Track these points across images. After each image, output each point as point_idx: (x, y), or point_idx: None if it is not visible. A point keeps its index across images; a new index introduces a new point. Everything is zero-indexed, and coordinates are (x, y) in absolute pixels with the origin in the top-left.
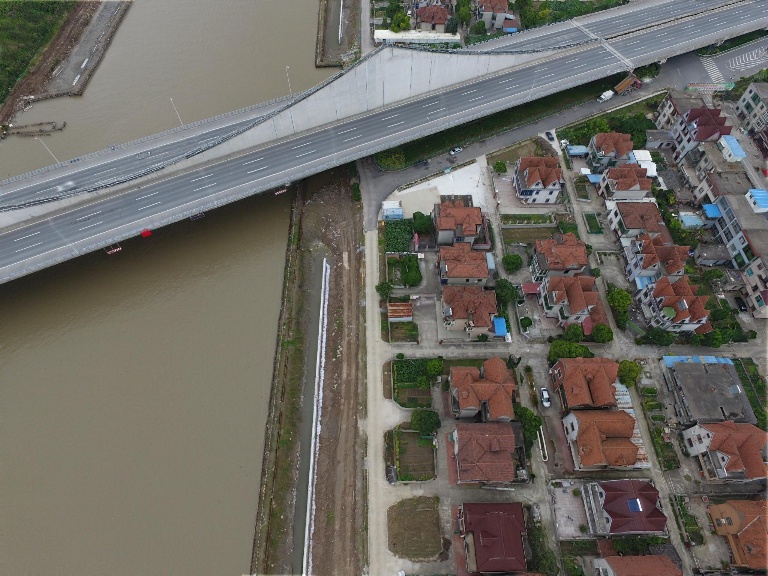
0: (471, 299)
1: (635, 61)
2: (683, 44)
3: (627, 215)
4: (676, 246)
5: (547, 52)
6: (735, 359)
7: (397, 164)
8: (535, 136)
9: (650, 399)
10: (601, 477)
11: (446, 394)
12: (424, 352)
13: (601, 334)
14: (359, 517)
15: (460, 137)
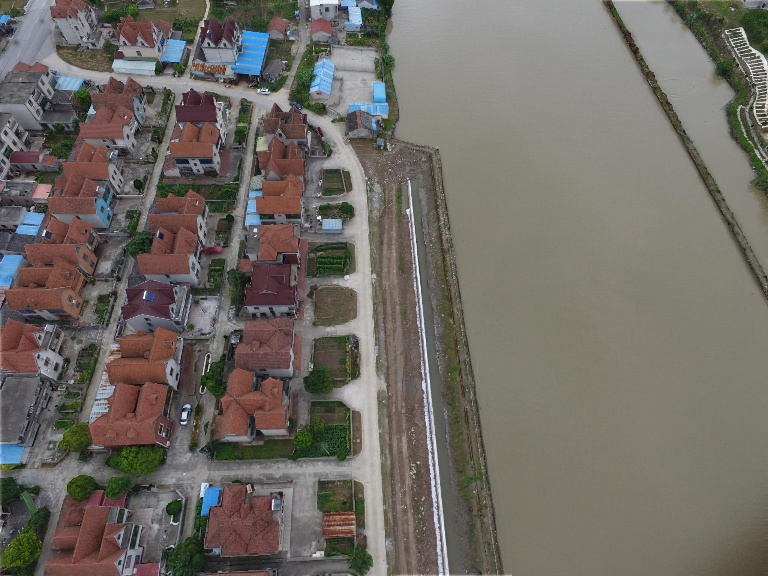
0: (242, 521)
1: None
2: None
3: None
4: None
5: None
6: None
7: None
8: None
9: (68, 416)
10: None
11: (294, 417)
12: (313, 469)
13: (85, 481)
14: (380, 312)
15: None
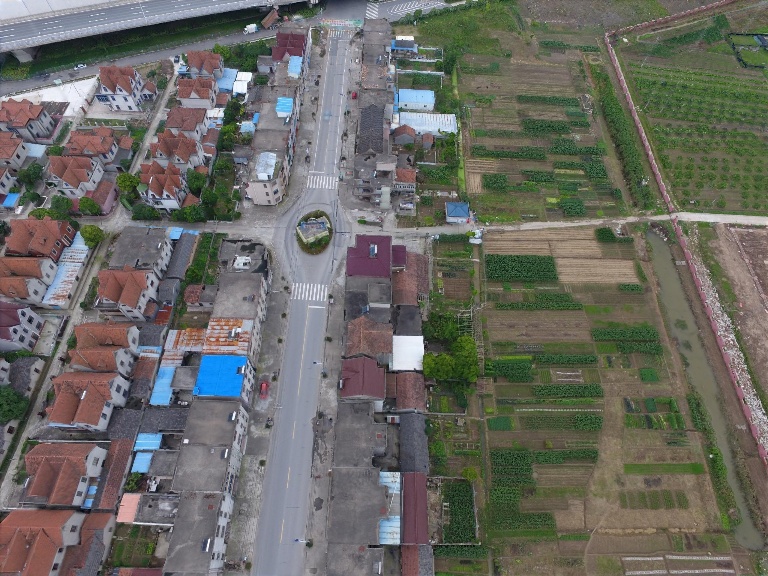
0: None
1: None
2: None
3: (169, 116)
4: None
5: None
6: (209, 233)
7: (18, 75)
8: (164, 59)
9: None
10: None
11: None
12: None
13: (79, 204)
14: None
15: (93, 57)
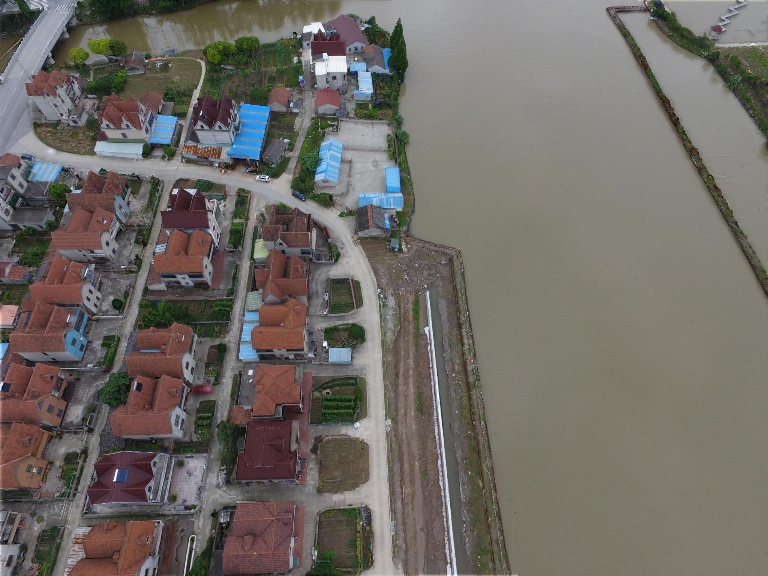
0: None
1: None
2: None
3: None
4: None
5: None
6: None
7: None
8: None
9: None
10: (138, 517)
11: None
12: None
13: None
14: (397, 472)
15: None
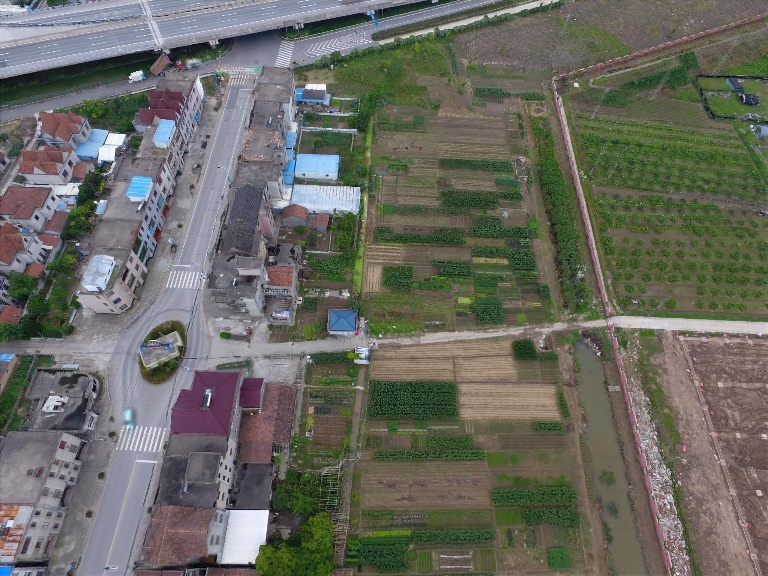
0: None
1: (169, 40)
2: (243, 25)
3: (2, 200)
4: (5, 234)
5: (61, 27)
6: (30, 356)
7: None
8: (27, 115)
9: None
10: None
11: None
12: None
13: None
14: None
15: None
